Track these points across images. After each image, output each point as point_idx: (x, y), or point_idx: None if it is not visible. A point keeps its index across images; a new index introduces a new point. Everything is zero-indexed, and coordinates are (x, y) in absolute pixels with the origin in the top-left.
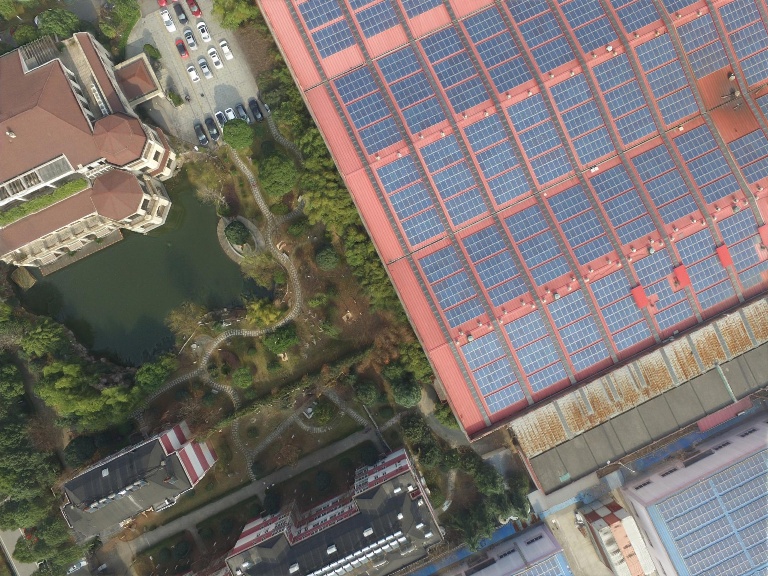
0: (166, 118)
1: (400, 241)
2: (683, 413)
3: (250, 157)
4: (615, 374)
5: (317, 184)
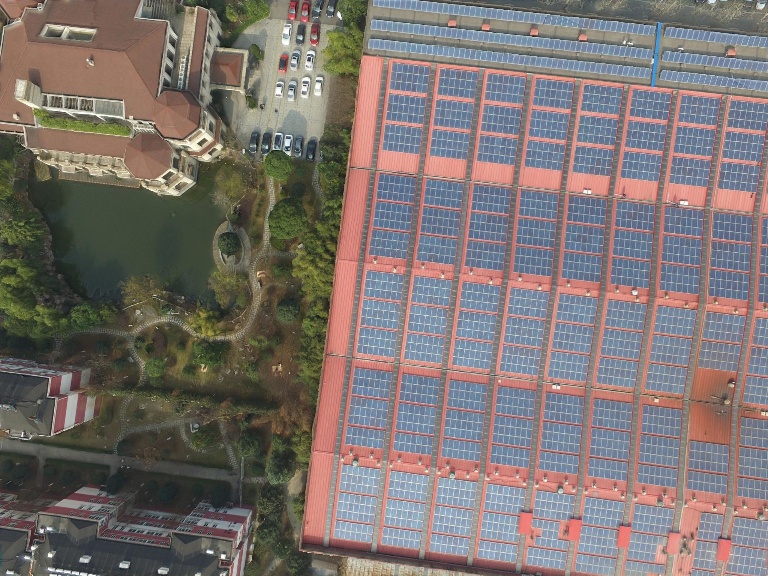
0: (235, 111)
1: (350, 341)
2: None
3: (282, 186)
4: None
5: (316, 247)
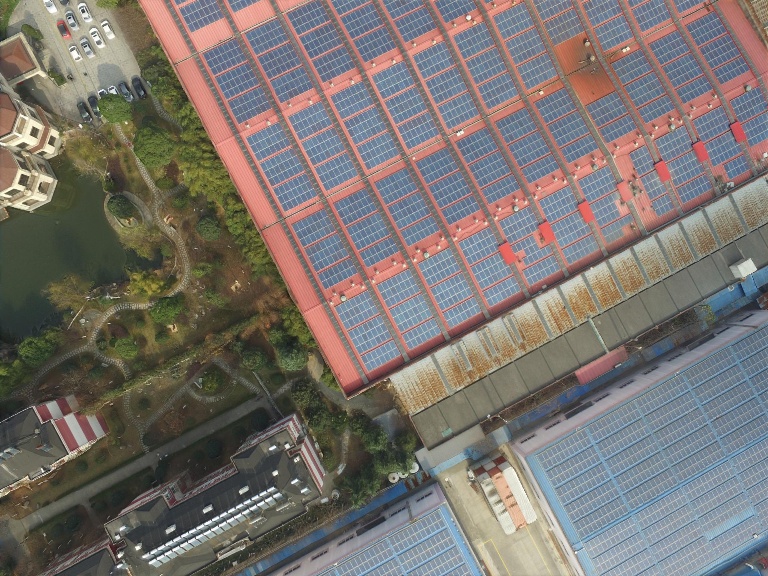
0: (49, 97)
1: (273, 207)
2: (559, 366)
3: (134, 133)
4: (492, 330)
5: (194, 155)
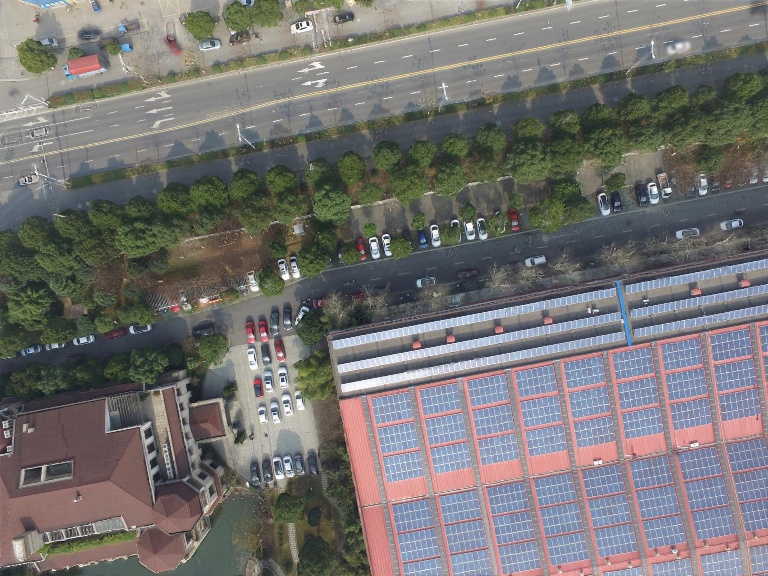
0: (227, 448)
1: None
2: None
3: None
4: None
5: None
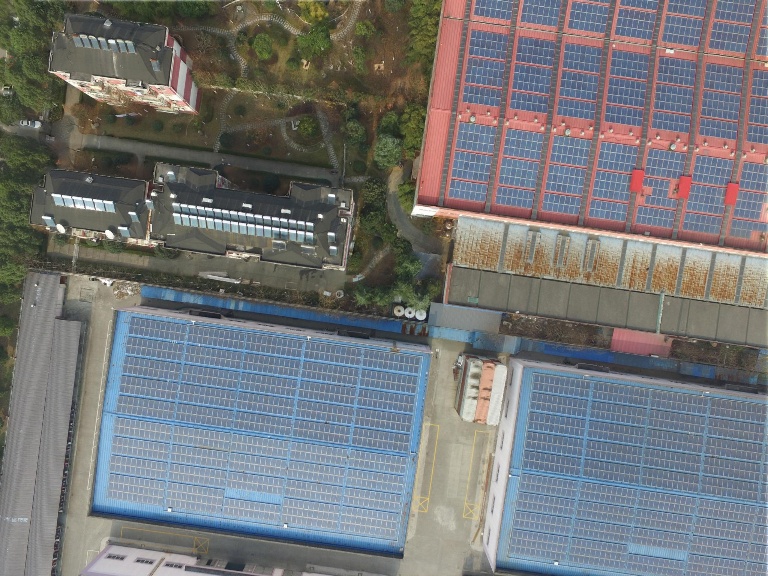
0: None
1: (467, 4)
2: (607, 314)
3: None
4: (572, 243)
5: None
